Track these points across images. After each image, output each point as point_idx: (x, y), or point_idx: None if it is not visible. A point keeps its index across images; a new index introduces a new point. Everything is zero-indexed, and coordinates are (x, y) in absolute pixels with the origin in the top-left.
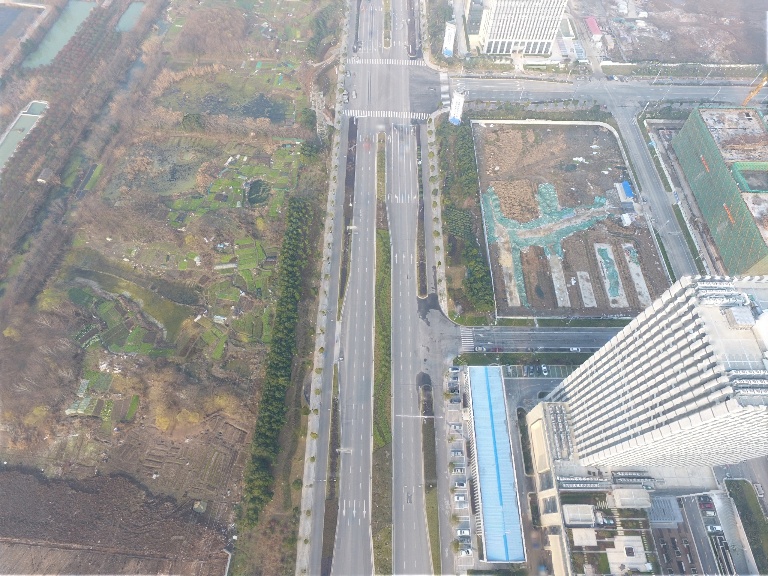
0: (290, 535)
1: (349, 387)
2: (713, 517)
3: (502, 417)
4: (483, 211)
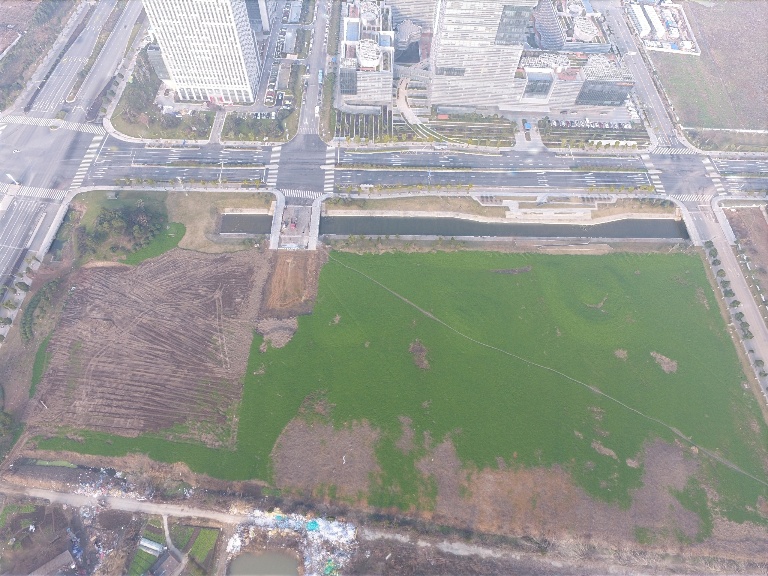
0: (55, 32)
1: None
2: (284, 38)
3: None
4: None
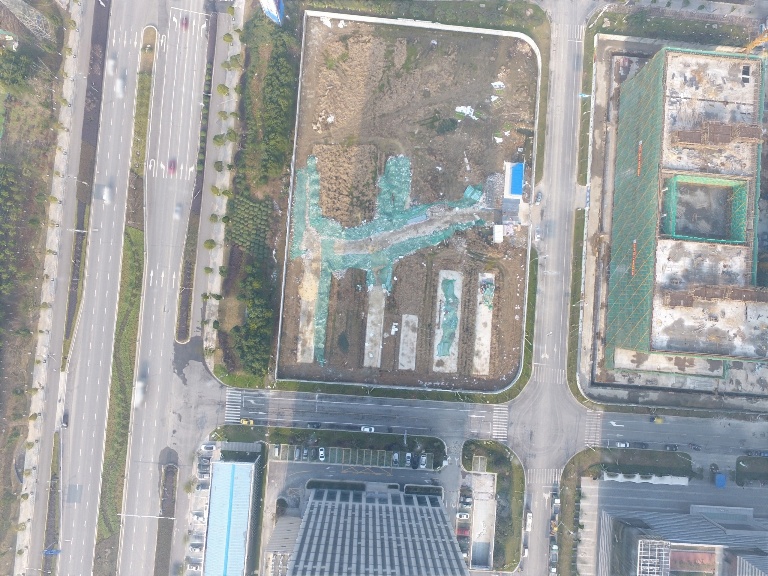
0: None
1: (73, 462)
2: None
3: (242, 528)
4: (291, 204)
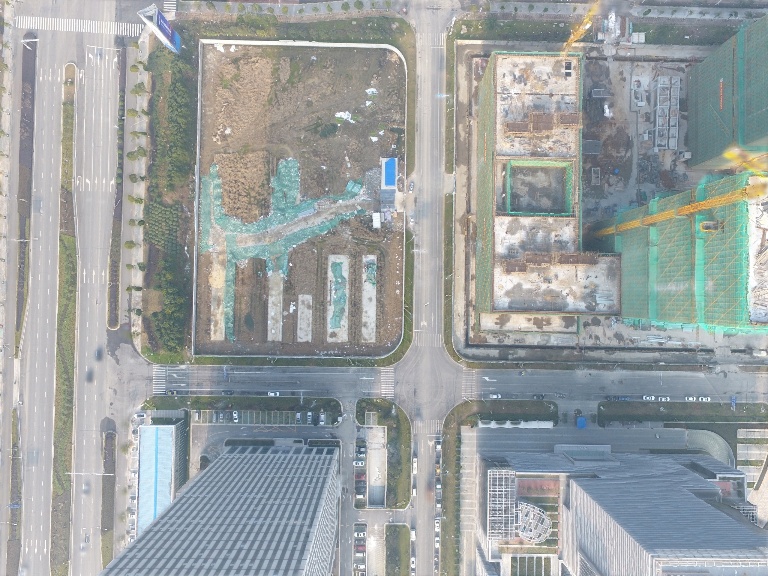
0: None
1: (30, 433)
2: (363, 556)
3: (167, 480)
4: (197, 206)
